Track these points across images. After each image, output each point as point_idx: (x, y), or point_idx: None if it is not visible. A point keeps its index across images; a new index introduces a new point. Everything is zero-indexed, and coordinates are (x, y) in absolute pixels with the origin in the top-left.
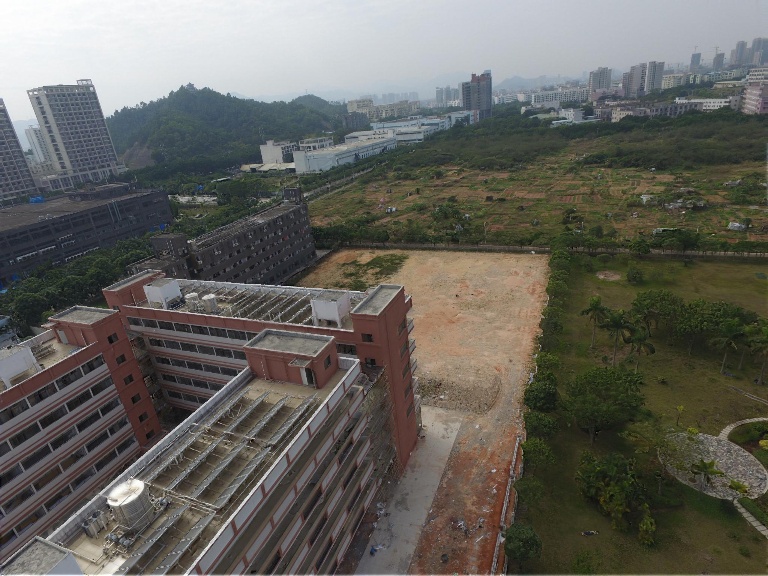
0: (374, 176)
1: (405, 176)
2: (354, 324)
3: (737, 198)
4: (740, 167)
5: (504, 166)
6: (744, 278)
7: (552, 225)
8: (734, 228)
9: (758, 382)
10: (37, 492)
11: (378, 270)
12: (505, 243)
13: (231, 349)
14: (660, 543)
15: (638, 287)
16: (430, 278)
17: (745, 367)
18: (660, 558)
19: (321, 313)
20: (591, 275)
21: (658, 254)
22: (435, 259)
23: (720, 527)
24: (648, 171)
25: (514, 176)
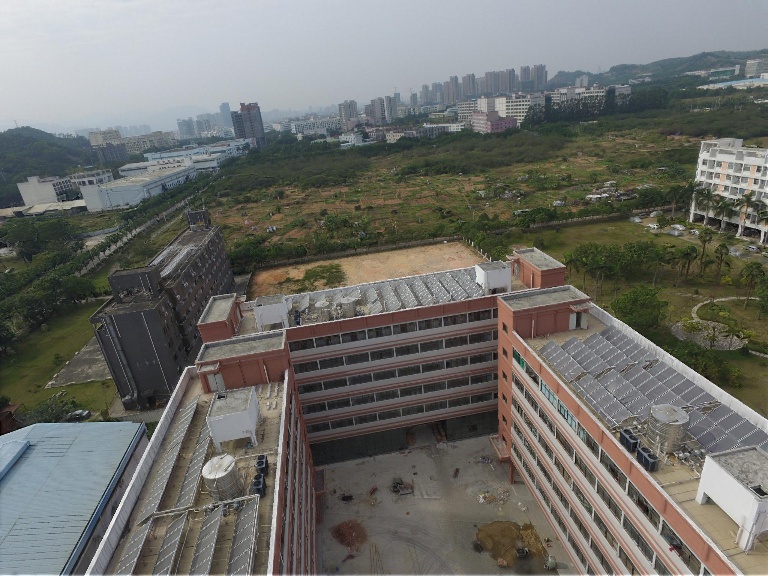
0: (208, 203)
1: (246, 199)
2: (542, 280)
3: (539, 186)
4: (514, 168)
5: (337, 182)
6: (597, 233)
7: (436, 220)
8: (558, 204)
9: (676, 286)
10: (308, 569)
11: (325, 281)
12: (421, 238)
13: (394, 347)
14: (741, 383)
15: (546, 250)
16: (385, 276)
17: (660, 280)
18: (750, 390)
19: (493, 283)
20: (507, 249)
21: (533, 228)
22: (368, 262)
23: (752, 363)
24: (457, 175)
25: (355, 189)
